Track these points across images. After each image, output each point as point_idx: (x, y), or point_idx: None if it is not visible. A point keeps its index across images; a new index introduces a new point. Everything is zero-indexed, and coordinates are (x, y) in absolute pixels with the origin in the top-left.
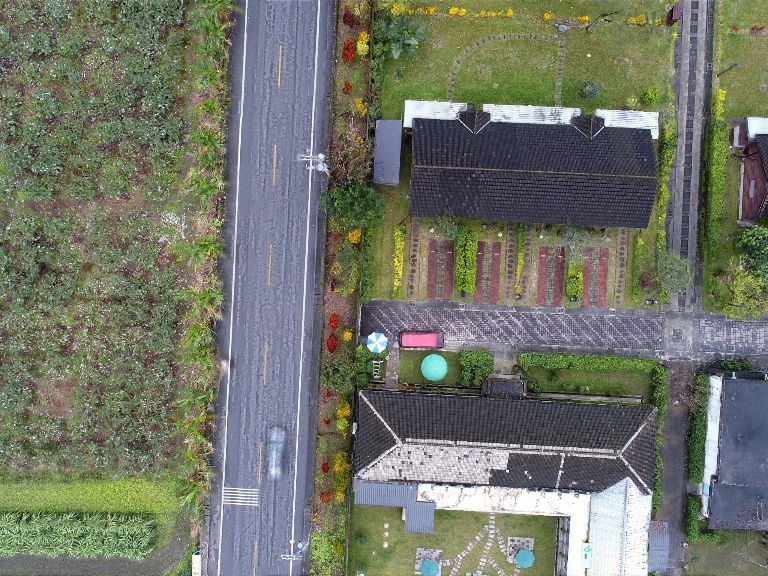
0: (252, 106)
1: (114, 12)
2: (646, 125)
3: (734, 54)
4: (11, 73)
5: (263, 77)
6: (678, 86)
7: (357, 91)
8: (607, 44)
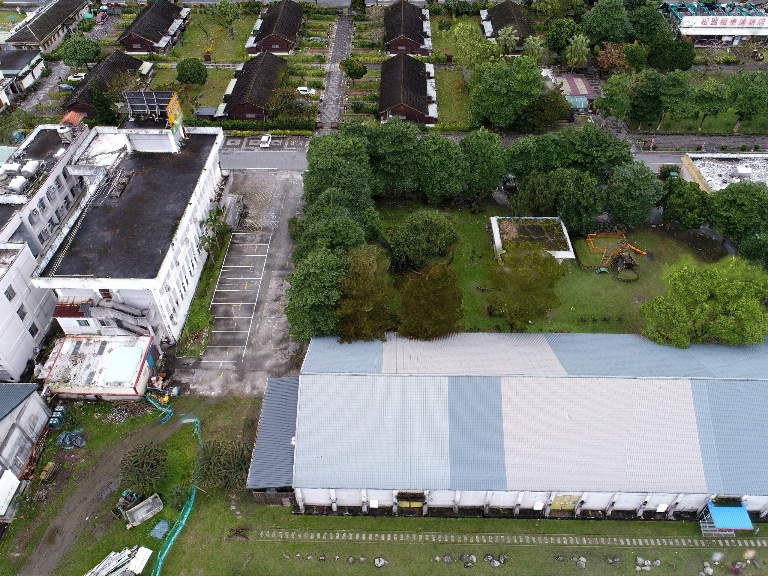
0: None
1: None
2: (160, 44)
3: None
4: None
5: None
6: None
7: None
8: None
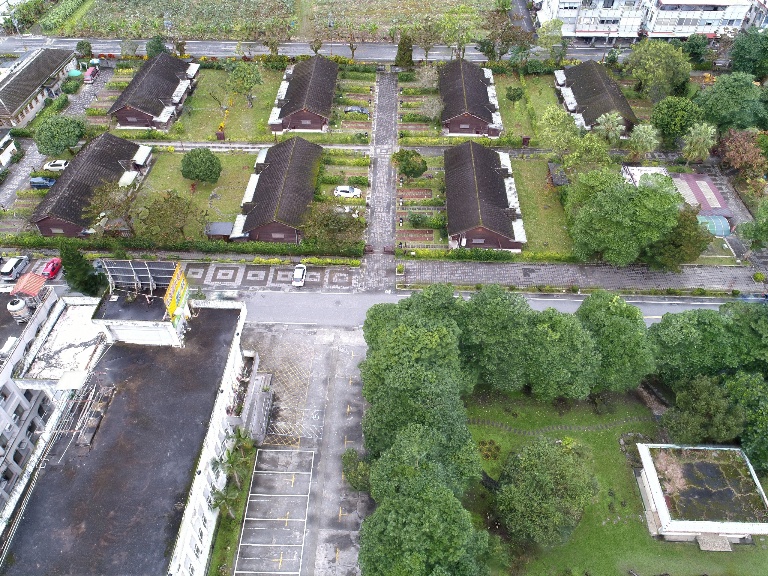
0: None
1: None
2: None
3: None
4: (247, 8)
5: None
6: None
7: None
8: None
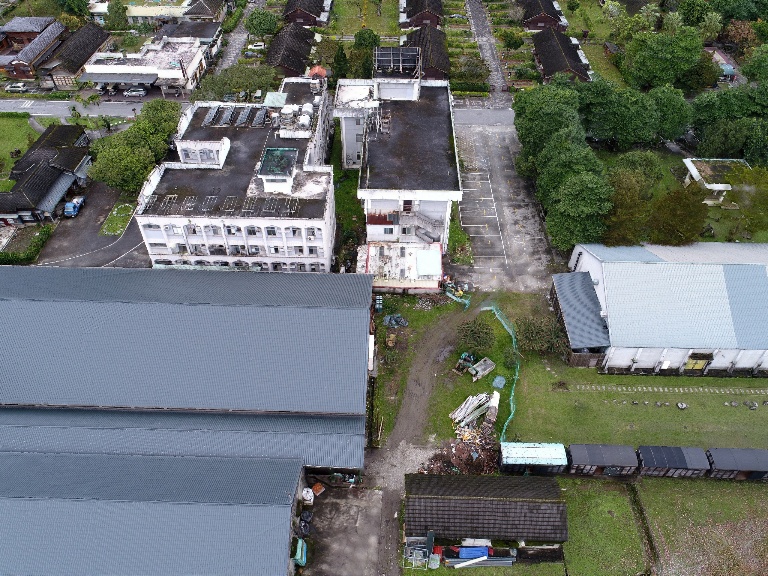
0: None
1: None
2: None
3: None
4: None
5: None
6: None
7: None
8: None
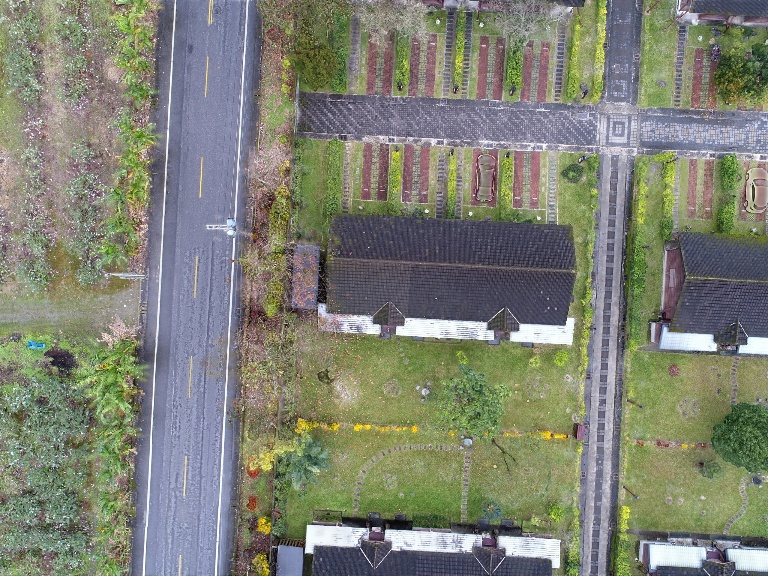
0: (157, 516)
1: (21, 416)
2: (548, 554)
3: (640, 465)
4: None
5: (168, 487)
6: (584, 496)
7: (263, 499)
8: (513, 455)
